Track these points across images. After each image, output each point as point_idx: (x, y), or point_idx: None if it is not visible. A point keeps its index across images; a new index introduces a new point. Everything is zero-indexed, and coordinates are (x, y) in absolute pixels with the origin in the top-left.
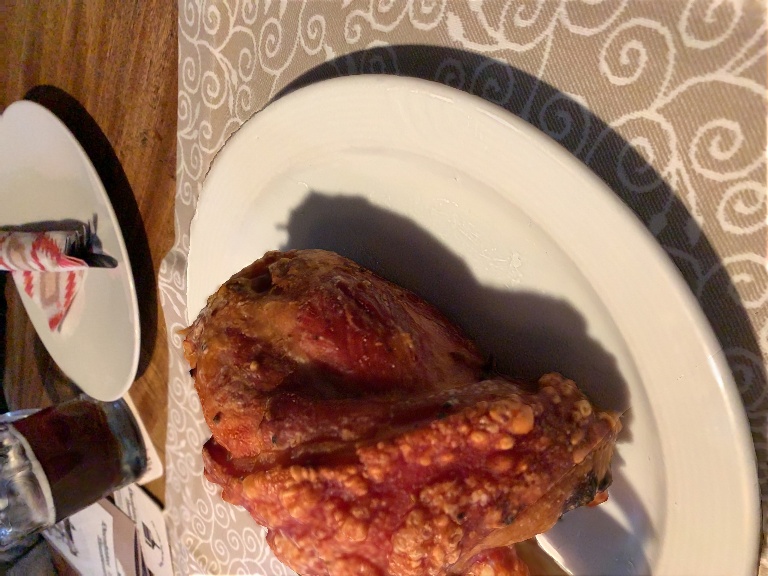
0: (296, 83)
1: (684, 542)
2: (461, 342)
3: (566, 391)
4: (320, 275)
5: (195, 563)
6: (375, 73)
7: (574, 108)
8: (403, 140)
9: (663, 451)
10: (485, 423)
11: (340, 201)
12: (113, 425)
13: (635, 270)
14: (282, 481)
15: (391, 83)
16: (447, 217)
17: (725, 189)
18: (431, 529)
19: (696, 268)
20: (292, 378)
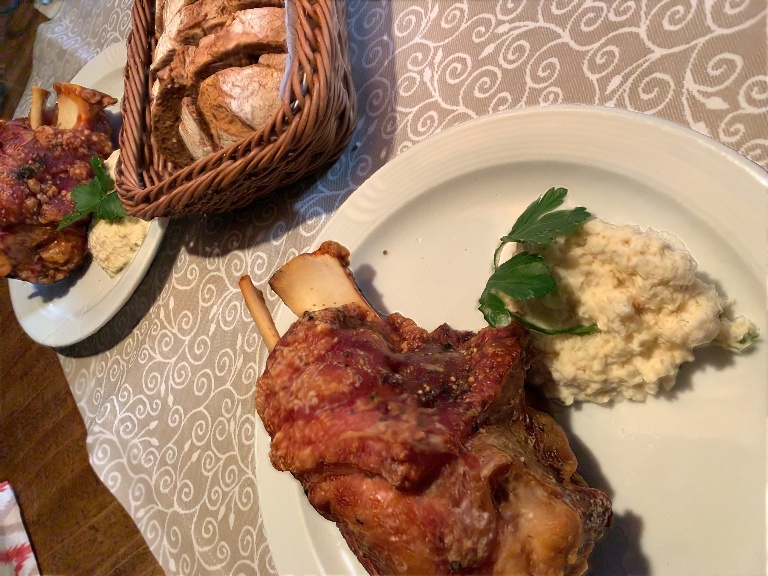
0: None
1: None
2: None
3: None
4: None
5: None
6: None
7: None
8: None
9: None
10: None
11: None
12: None
13: (273, 517)
14: None
15: None
16: None
17: None
18: None
19: None
20: None
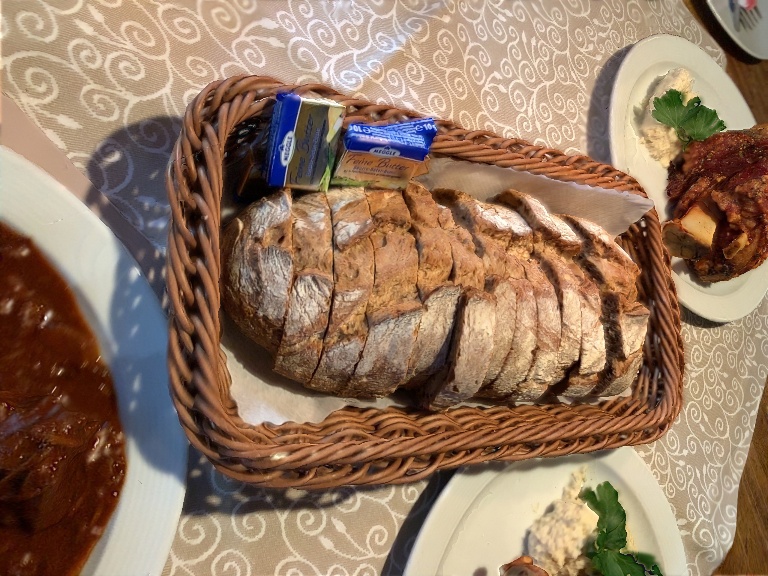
0: None
1: None
2: None
3: None
4: None
5: None
6: None
7: None
8: None
9: None
10: None
11: None
12: None
13: None
14: None
15: None
16: None
17: None
18: None
19: None
20: None
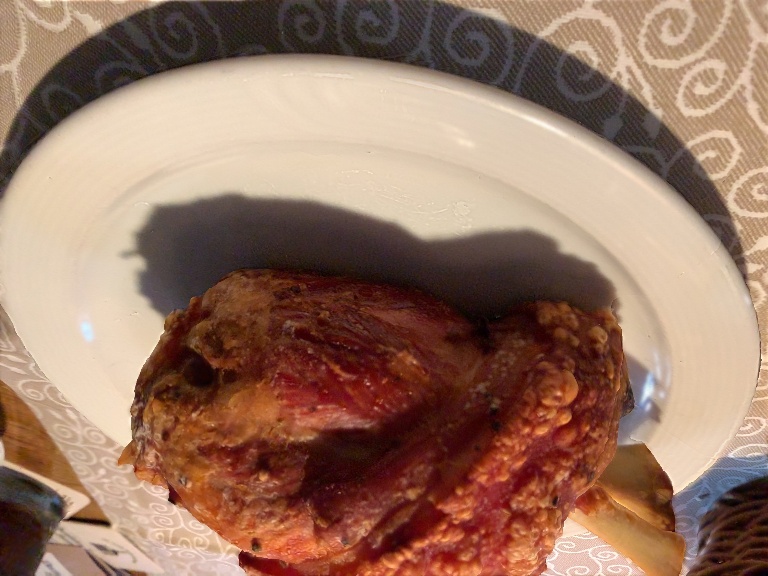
0: (53, 76)
1: (691, 384)
2: (438, 313)
3: (574, 325)
4: (266, 331)
5: (175, 546)
6: (210, 60)
7: (489, 25)
8: (286, 132)
9: (664, 329)
10: (544, 415)
11: (203, 206)
12: (3, 495)
13: (627, 201)
14: (380, 575)
15: (246, 71)
16: (360, 187)
17: (683, 75)
18: (538, 529)
19: (658, 158)
20: (312, 463)
